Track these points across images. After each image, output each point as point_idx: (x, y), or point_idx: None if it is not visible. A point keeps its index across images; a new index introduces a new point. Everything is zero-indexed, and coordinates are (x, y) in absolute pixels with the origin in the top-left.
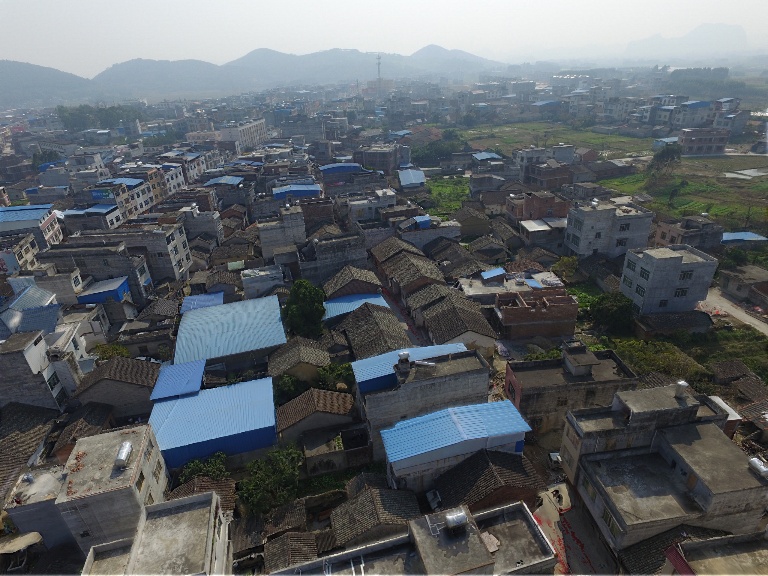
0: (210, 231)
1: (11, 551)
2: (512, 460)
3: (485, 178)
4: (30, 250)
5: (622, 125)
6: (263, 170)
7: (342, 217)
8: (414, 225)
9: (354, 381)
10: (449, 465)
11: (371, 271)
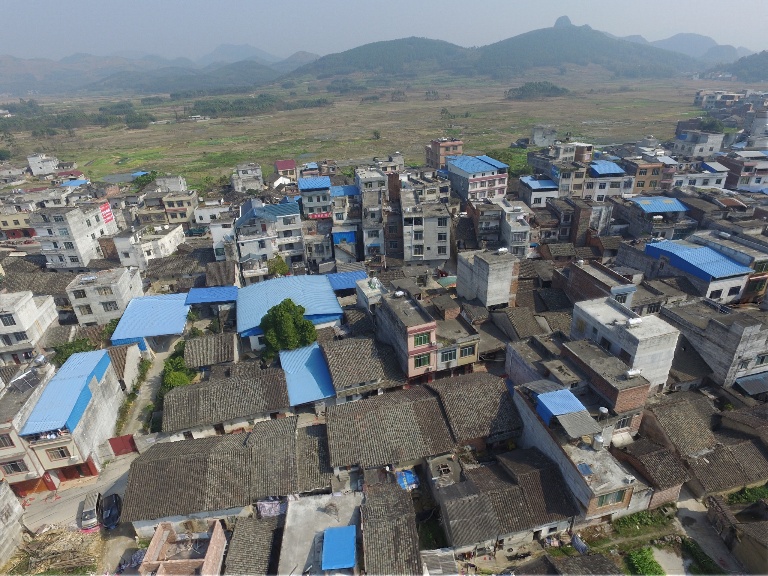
0: None
1: None
2: None
3: None
4: (436, 192)
5: None
6: (753, 213)
7: None
8: None
9: None
10: None
11: (384, 373)
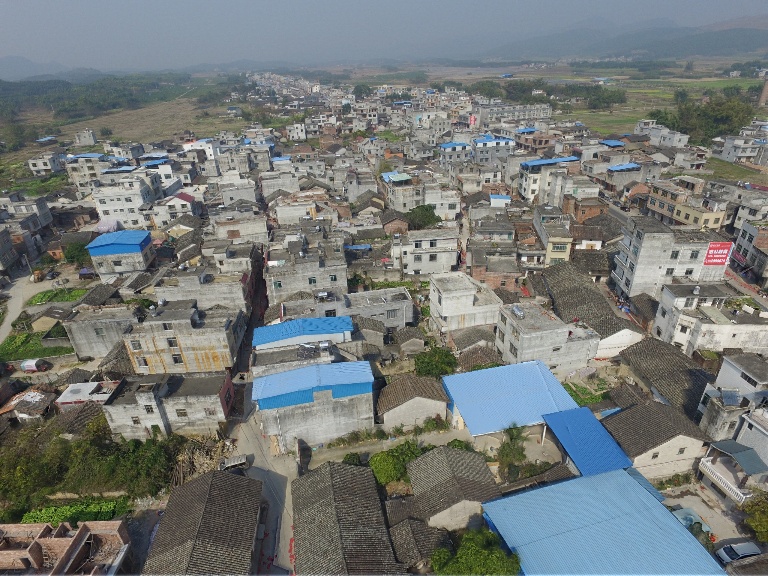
0: None
1: (597, 363)
2: None
3: None
4: None
5: None
6: None
7: None
8: None
9: None
10: None
11: None
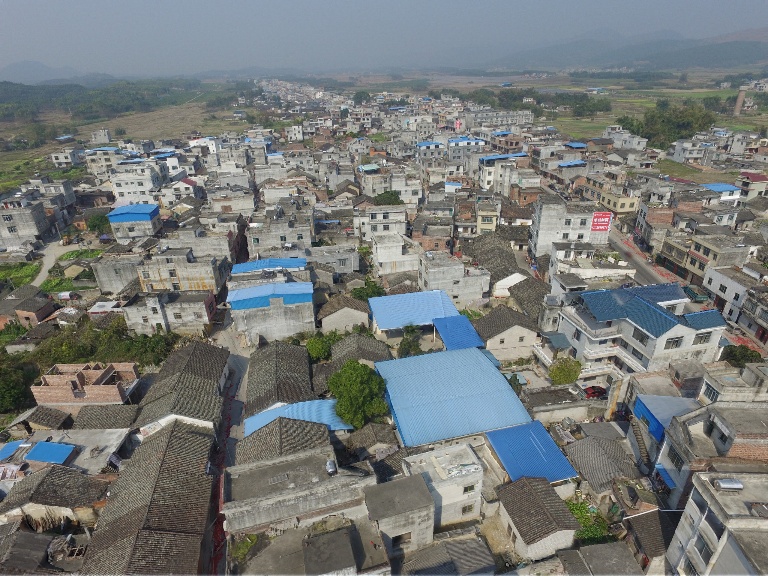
0: None
1: None
2: None
3: None
4: None
5: None
6: None
7: None
8: None
9: None
10: None
11: None
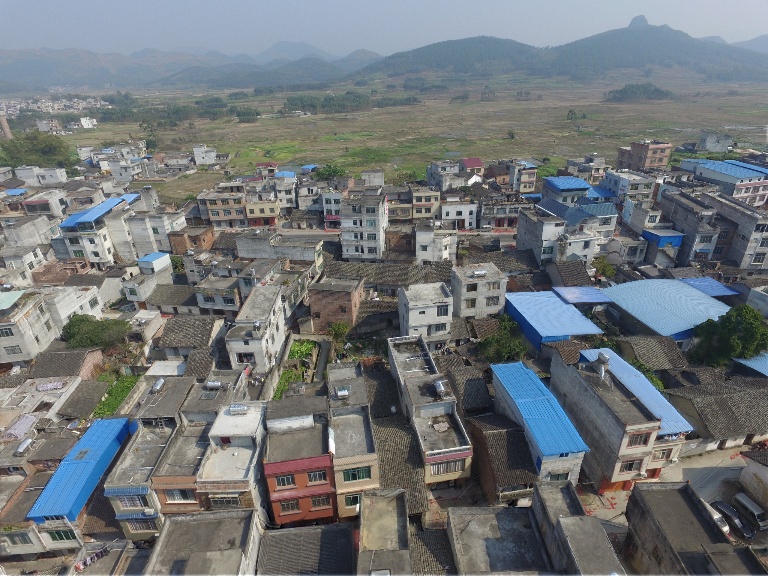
0: None
1: None
2: (523, 457)
3: None
4: None
5: None
6: None
7: None
8: None
9: None
10: (509, 414)
11: None
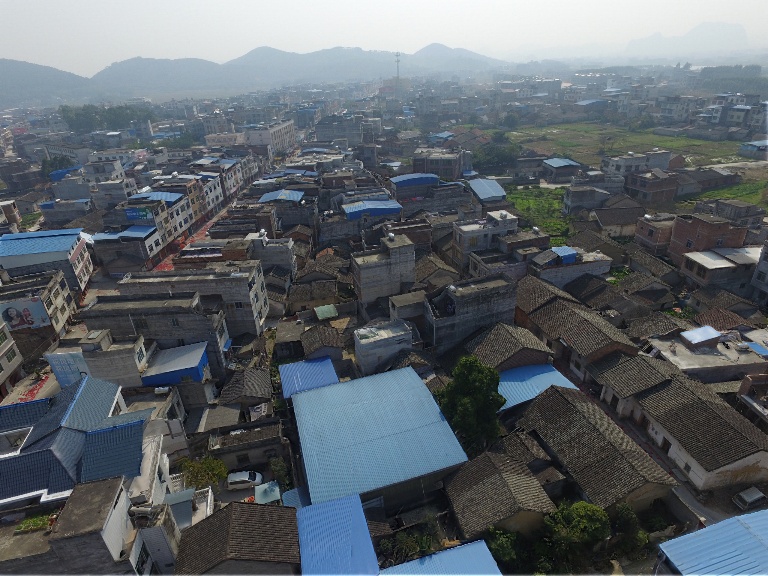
0: (283, 264)
1: None
2: None
3: (587, 191)
4: (60, 293)
5: (685, 126)
6: (322, 182)
7: (435, 242)
8: (555, 260)
9: (602, 538)
10: None
11: None
